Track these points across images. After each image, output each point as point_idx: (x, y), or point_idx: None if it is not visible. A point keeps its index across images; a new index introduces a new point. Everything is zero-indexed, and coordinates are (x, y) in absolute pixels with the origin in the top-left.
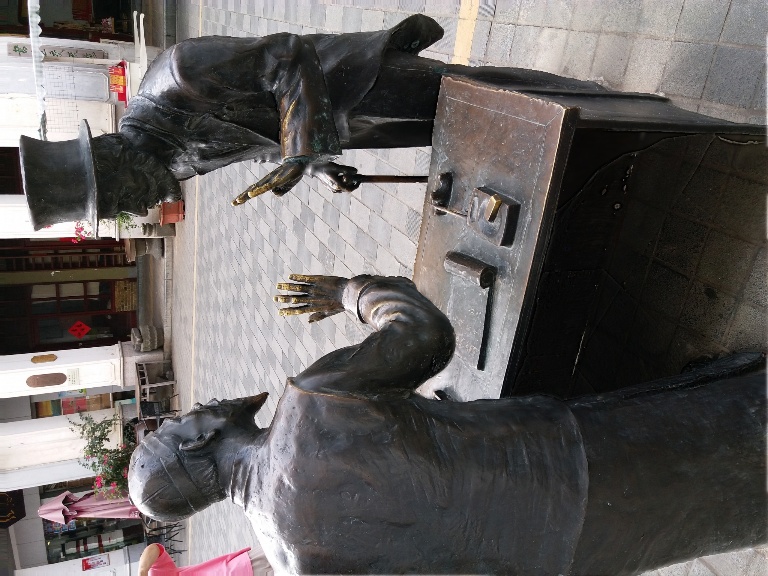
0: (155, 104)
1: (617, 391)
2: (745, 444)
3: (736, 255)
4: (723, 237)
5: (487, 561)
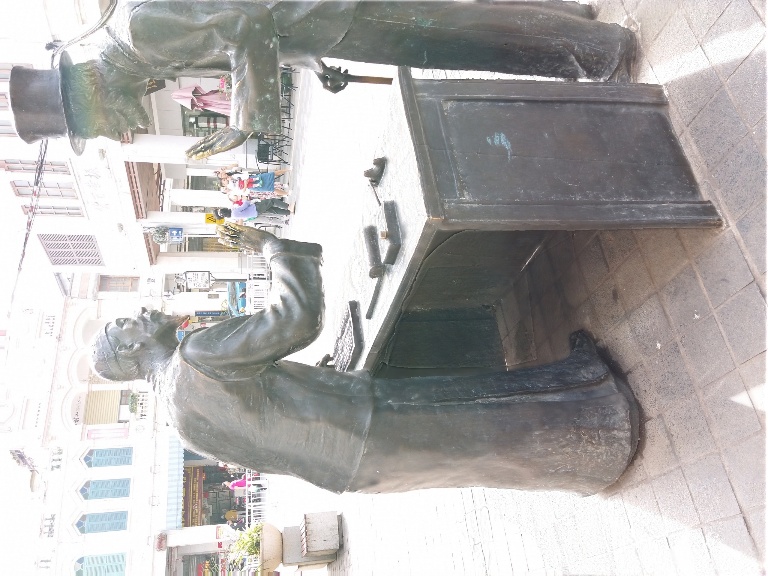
0: (122, 50)
1: (439, 389)
2: (514, 454)
3: (641, 283)
4: (641, 261)
5: (291, 472)
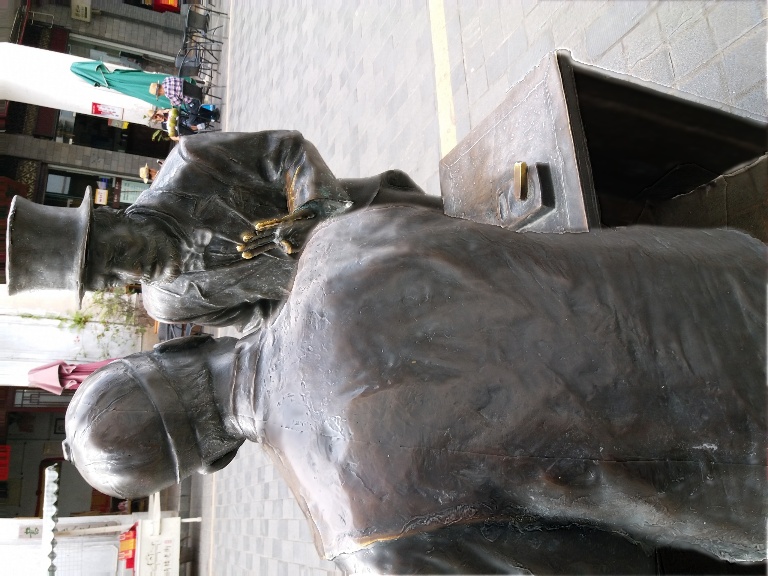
0: (161, 191)
1: None
2: None
3: None
4: None
5: (681, 392)
